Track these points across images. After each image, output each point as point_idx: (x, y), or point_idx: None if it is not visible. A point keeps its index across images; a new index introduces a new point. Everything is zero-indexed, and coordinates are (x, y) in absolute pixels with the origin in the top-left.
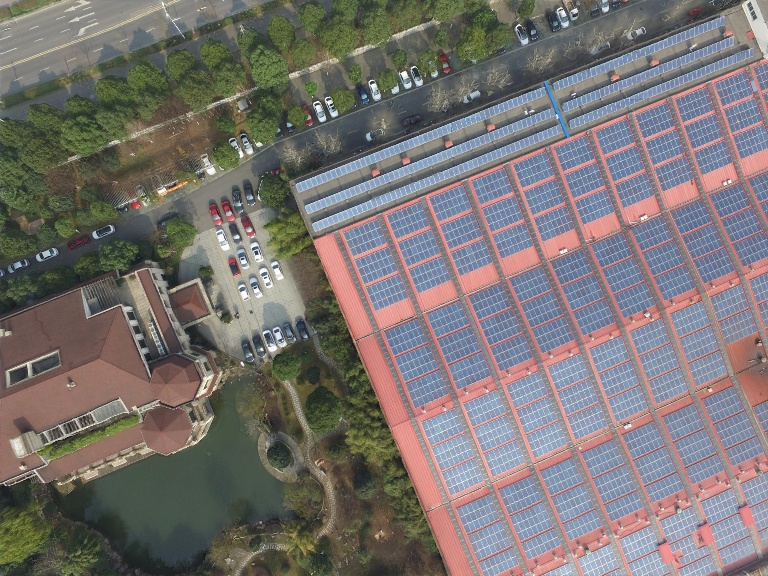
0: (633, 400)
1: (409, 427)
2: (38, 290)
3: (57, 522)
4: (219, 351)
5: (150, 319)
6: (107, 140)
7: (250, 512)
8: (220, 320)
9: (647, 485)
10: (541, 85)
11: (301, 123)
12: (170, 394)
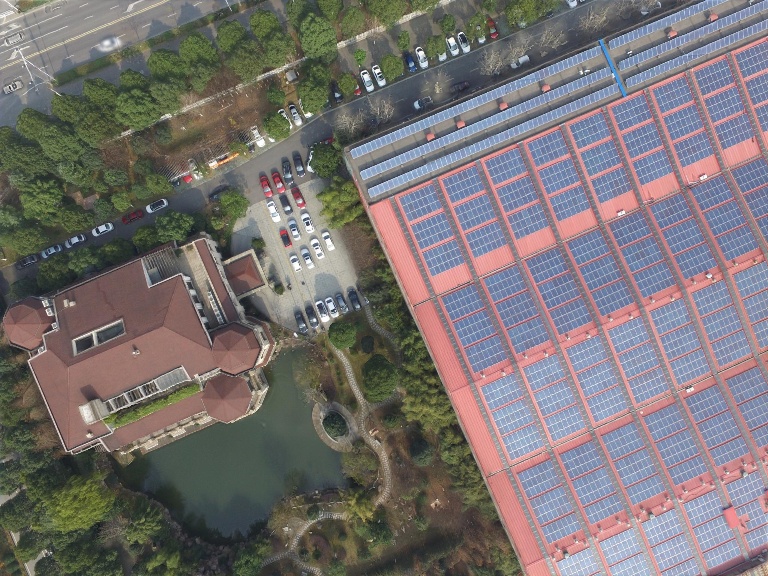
0: (695, 363)
1: (468, 392)
2: (98, 262)
3: (118, 492)
4: (272, 322)
5: (208, 289)
6: (160, 113)
7: (306, 482)
8: (273, 291)
9: (711, 449)
10: (596, 44)
11: (350, 92)
12: (232, 361)
